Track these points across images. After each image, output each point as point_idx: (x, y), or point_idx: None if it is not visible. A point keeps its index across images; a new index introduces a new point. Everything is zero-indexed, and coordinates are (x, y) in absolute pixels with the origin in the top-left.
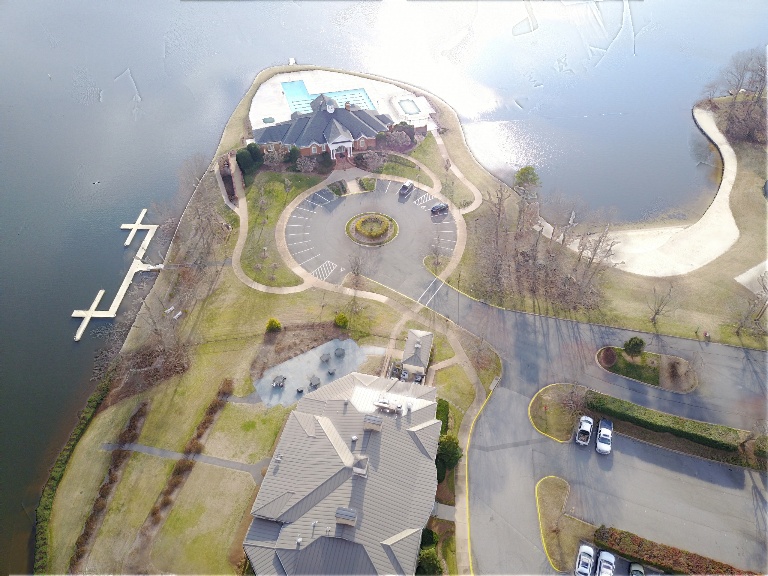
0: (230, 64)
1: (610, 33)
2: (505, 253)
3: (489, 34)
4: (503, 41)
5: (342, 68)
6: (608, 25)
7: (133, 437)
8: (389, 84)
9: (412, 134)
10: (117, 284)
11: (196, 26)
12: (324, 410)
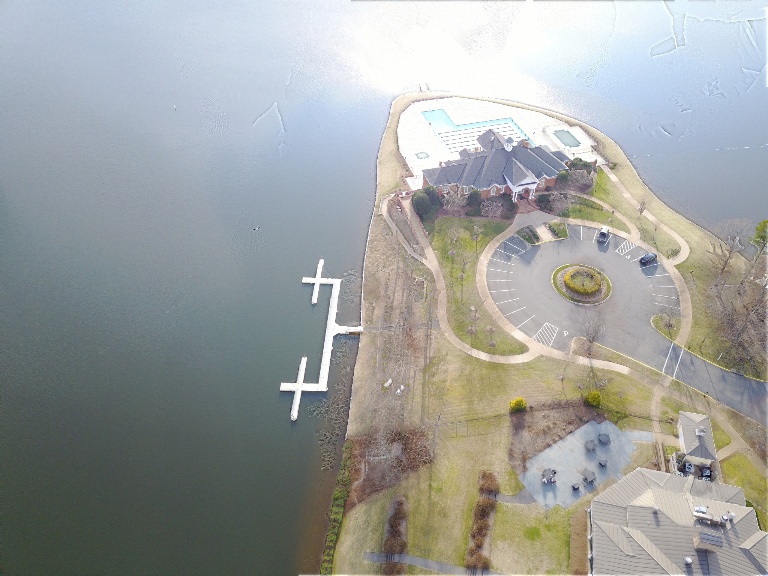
0: (356, 90)
1: (764, 54)
2: (734, 311)
3: (626, 55)
4: (642, 62)
5: (478, 94)
6: (762, 45)
7: (403, 547)
8: (536, 112)
9: (589, 171)
10: (315, 349)
11: (322, 51)
12: (628, 519)
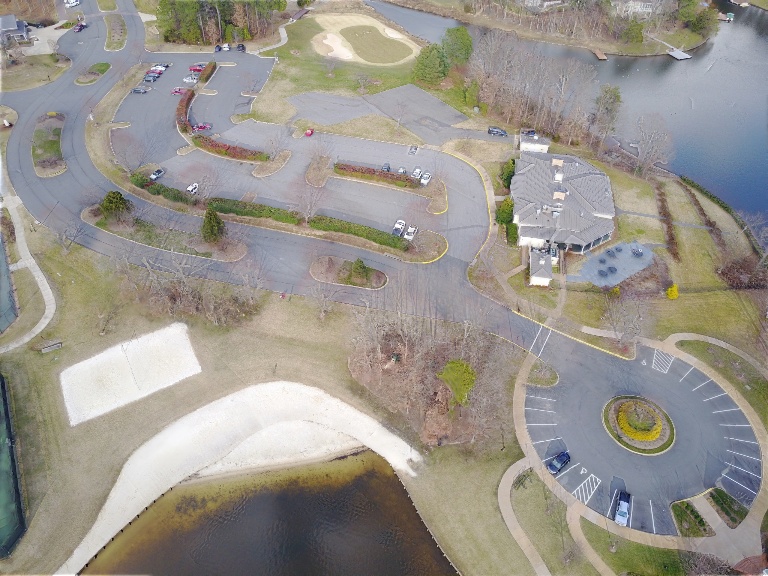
0: None
1: None
2: None
3: None
4: None
5: None
6: None
7: None
8: None
9: None
10: None
11: None
12: None
